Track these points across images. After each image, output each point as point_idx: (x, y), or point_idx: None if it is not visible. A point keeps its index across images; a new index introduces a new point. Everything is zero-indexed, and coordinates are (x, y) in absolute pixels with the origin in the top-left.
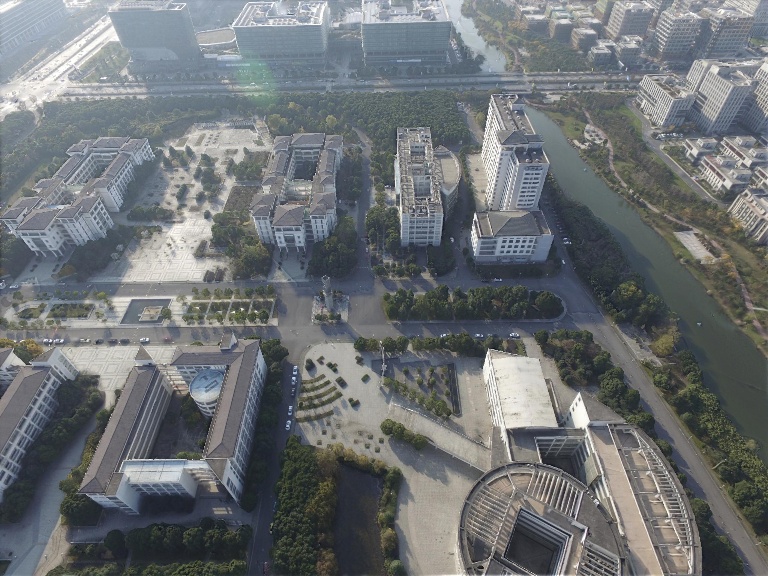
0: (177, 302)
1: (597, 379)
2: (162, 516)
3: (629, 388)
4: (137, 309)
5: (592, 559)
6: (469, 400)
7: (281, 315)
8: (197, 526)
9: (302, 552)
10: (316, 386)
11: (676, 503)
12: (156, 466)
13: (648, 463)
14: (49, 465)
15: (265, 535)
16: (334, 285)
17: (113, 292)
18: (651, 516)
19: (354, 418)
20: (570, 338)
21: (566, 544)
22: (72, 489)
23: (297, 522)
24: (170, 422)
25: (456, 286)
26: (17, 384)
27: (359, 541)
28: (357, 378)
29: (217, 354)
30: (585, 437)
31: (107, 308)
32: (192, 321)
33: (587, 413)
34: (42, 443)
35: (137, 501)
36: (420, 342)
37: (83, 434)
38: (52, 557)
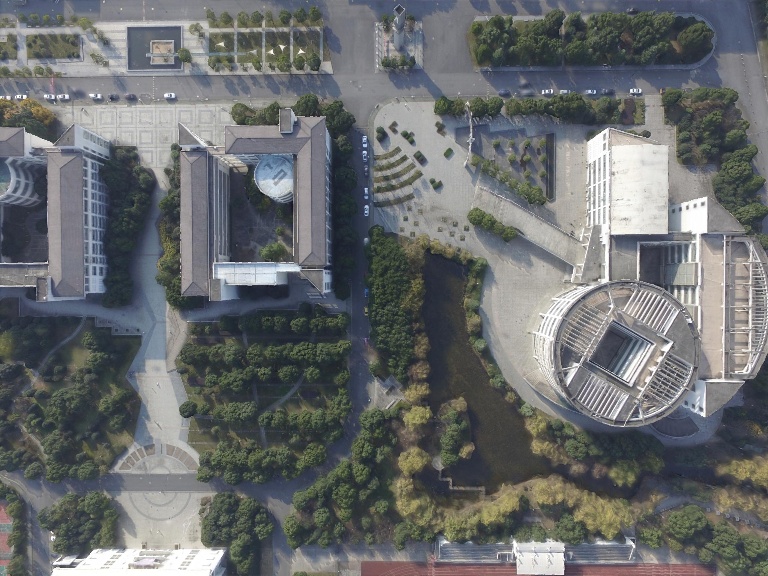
0: (190, 32)
1: (720, 158)
2: (262, 300)
3: (752, 167)
4: (141, 44)
5: (669, 367)
6: (566, 182)
7: (334, 56)
8: (300, 315)
9: (401, 339)
10: (392, 163)
11: (762, 316)
12: (248, 269)
13: (751, 278)
14: (131, 252)
15: (361, 317)
16: (400, 1)
17: (96, 13)
18: (731, 323)
19: (437, 203)
20: (707, 99)
21: (646, 350)
22: (171, 284)
23: (393, 315)
24: (239, 207)
25: (572, 4)
26: (56, 176)
27: (446, 321)
28: (438, 153)
29: (278, 140)
30: (692, 242)
31: (100, 42)
32: (220, 65)
33: (707, 223)
34: (115, 235)
35: (236, 291)
36: (518, 106)
37: (150, 219)
38: (176, 333)
